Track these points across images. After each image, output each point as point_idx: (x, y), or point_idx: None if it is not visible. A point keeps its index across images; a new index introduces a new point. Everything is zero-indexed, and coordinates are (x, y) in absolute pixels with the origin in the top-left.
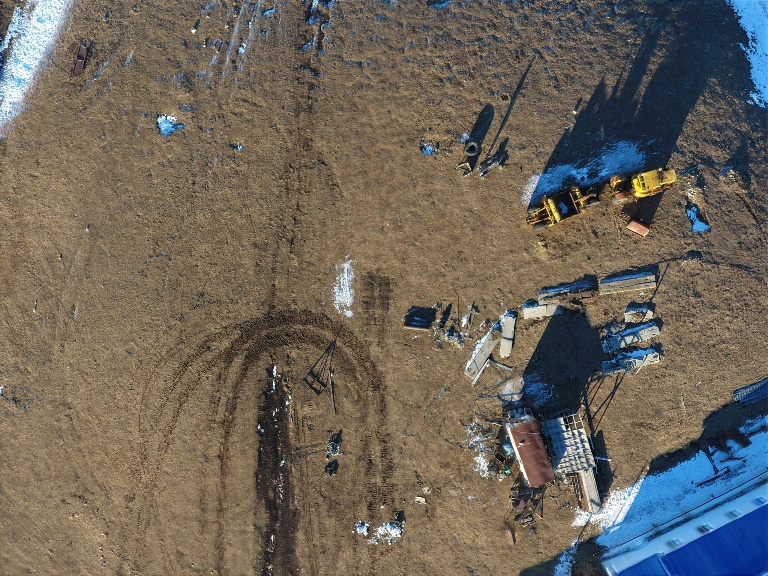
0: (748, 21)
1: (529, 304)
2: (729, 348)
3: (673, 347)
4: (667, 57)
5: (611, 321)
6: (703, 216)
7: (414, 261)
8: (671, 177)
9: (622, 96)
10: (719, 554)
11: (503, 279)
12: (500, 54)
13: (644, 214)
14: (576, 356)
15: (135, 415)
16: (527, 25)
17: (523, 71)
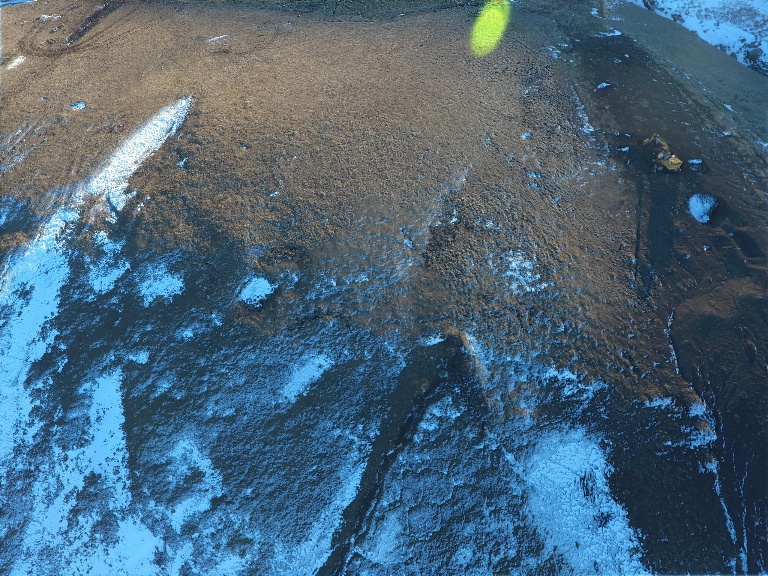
0: None
1: None
2: None
3: None
4: None
5: None
6: None
7: None
8: None
9: None
10: None
11: None
12: None
13: None
14: None
15: None
16: None
17: None
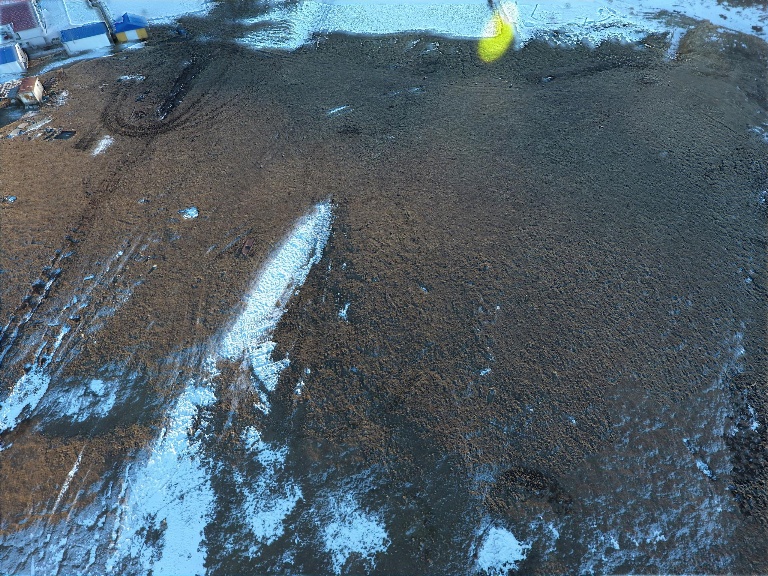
0: None
1: None
2: None
3: None
4: None
5: None
6: None
7: None
8: None
9: None
10: None
11: (4, 148)
12: None
13: None
14: None
15: None
16: None
17: None
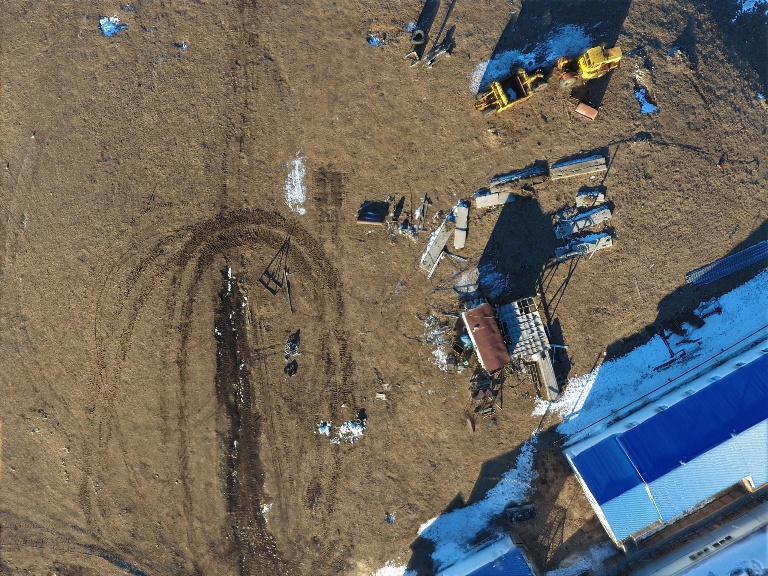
0: None
1: (481, 193)
2: (681, 229)
3: (625, 230)
4: None
5: (563, 206)
6: (651, 97)
7: (365, 155)
8: (617, 54)
9: None
10: (674, 429)
11: (455, 169)
12: None
13: (593, 97)
14: (530, 244)
15: (90, 324)
16: None
17: None
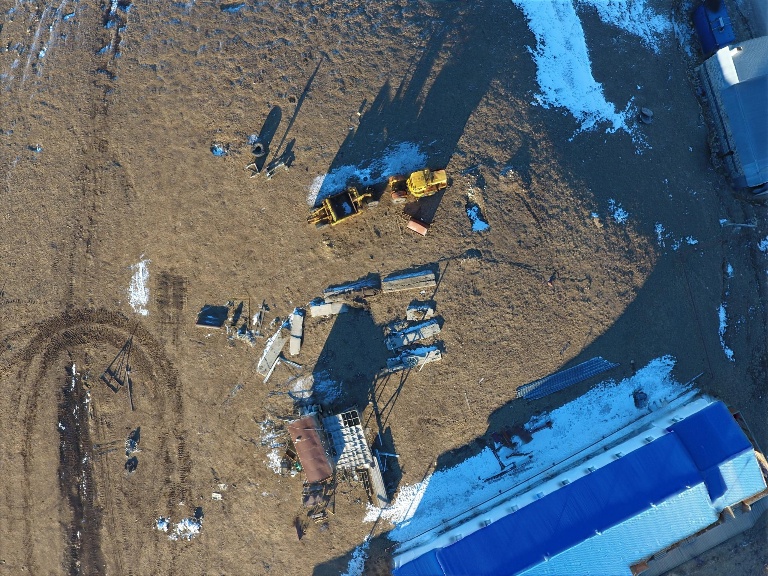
0: (538, 24)
1: (316, 302)
2: (510, 345)
3: (455, 344)
4: (451, 59)
5: (394, 319)
6: (483, 215)
7: (206, 260)
8: (441, 177)
9: (405, 98)
10: (490, 548)
11: (291, 278)
12: (289, 57)
13: (424, 213)
14: (362, 353)
15: None
16: (316, 28)
17: (311, 73)
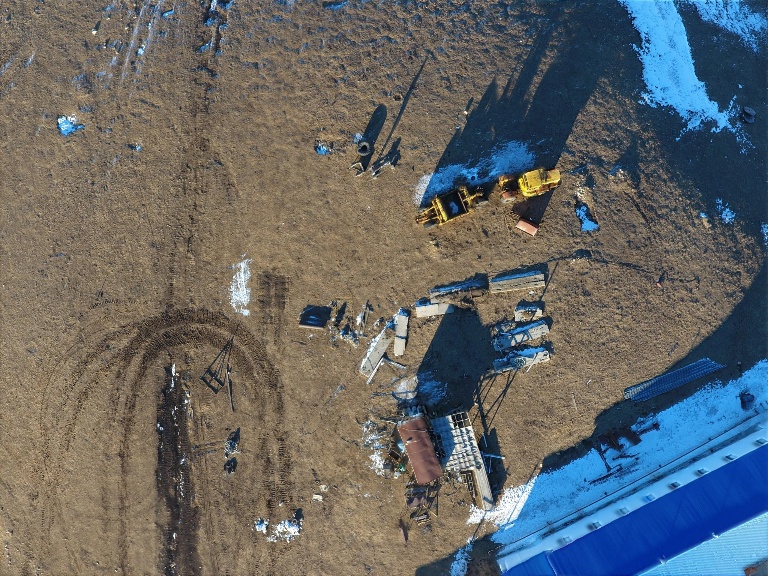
0: (642, 22)
1: (421, 303)
2: (619, 346)
3: (563, 345)
4: (558, 58)
5: (502, 319)
6: (592, 215)
7: (309, 260)
8: (555, 176)
9: (513, 96)
10: (604, 551)
11: (396, 278)
12: (393, 55)
13: (533, 213)
14: (468, 354)
15: (36, 413)
16: (420, 26)
17: (416, 72)
